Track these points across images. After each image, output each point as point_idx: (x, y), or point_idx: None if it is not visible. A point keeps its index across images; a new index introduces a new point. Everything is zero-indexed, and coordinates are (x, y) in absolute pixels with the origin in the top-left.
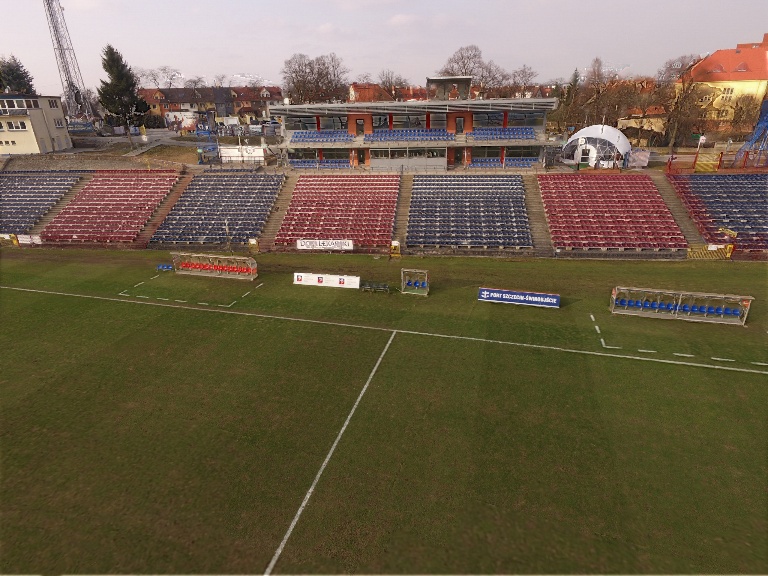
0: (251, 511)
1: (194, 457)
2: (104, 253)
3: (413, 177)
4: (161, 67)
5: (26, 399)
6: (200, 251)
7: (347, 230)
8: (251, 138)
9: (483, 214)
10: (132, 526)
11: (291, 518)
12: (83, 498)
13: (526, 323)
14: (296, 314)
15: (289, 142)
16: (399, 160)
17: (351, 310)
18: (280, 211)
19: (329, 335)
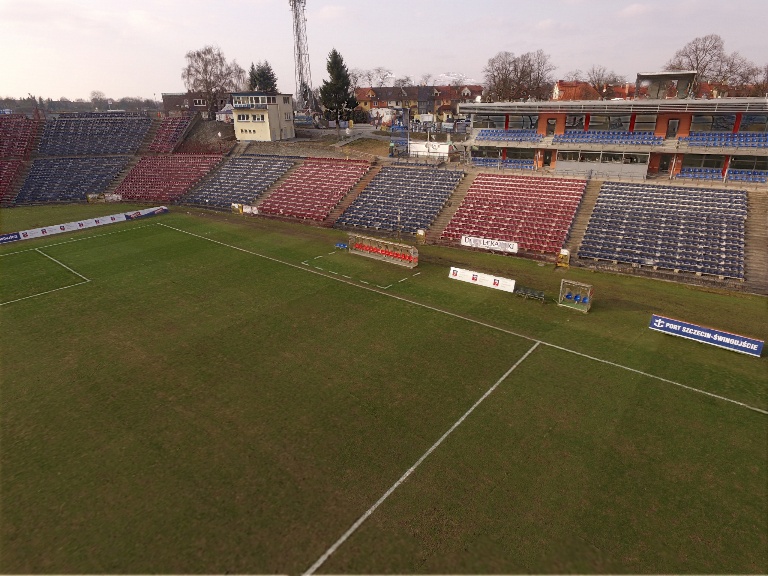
0: (355, 470)
1: (323, 410)
2: (299, 227)
3: (602, 184)
4: (376, 68)
5: (219, 332)
6: (374, 236)
7: (515, 232)
8: (442, 135)
9: (682, 233)
10: (264, 450)
11: (387, 488)
12: (237, 417)
13: (705, 365)
14: (443, 306)
15: (474, 140)
16: (589, 164)
17: (498, 312)
18: (452, 206)
19: (469, 332)
